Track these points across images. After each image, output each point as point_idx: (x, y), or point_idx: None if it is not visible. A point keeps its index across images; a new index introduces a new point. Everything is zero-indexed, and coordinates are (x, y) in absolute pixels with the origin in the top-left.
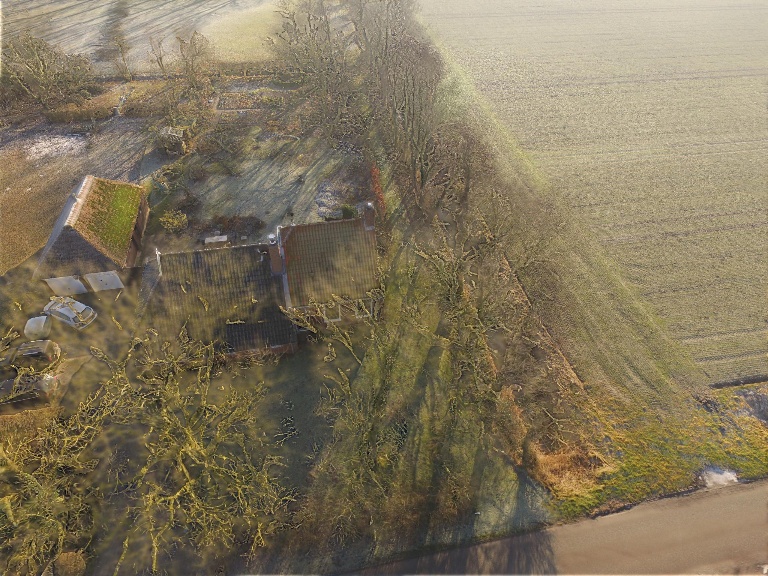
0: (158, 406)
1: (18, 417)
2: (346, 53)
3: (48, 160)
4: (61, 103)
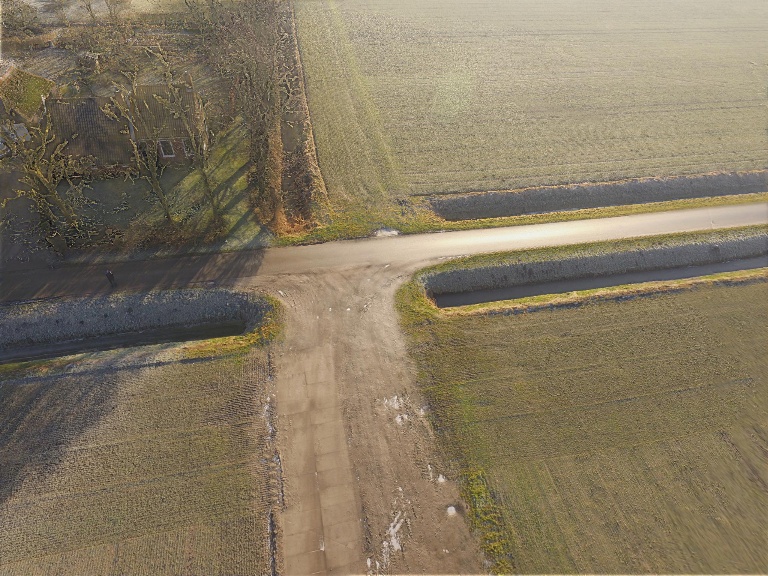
0: (4, 121)
1: None
2: None
3: None
4: (7, 37)
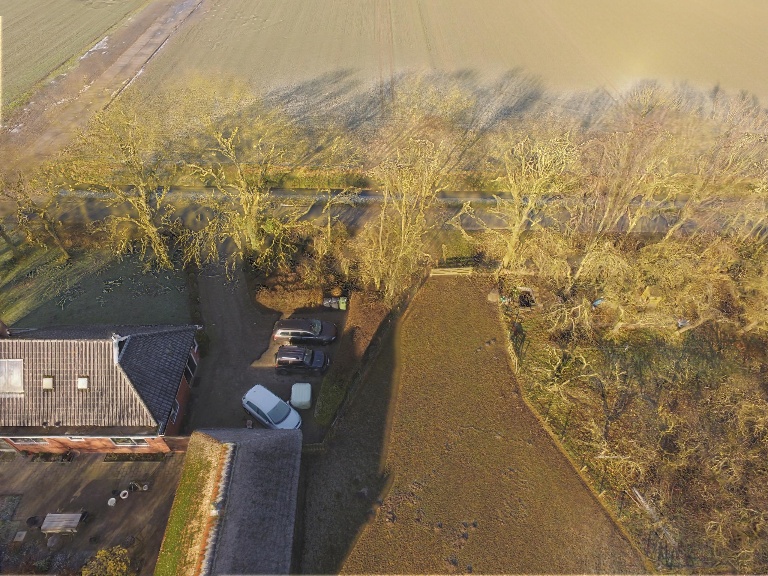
0: None
1: (288, 296)
2: None
3: None
4: None
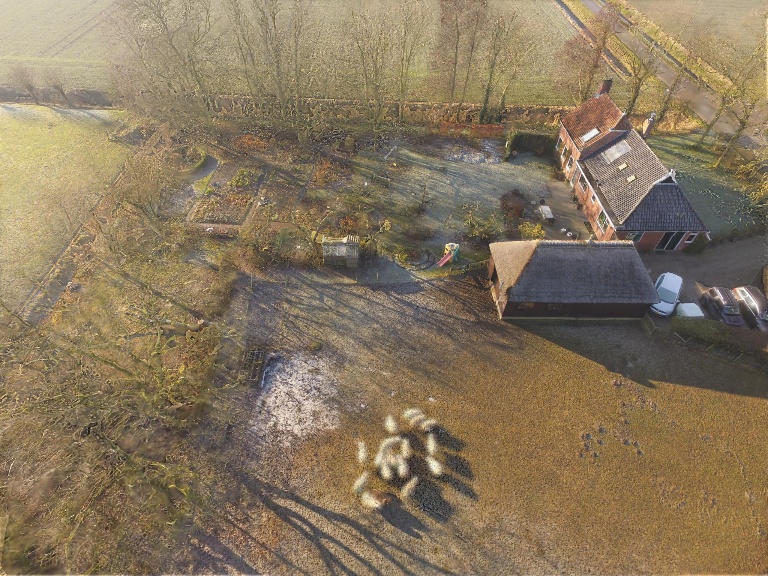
0: None
1: None
2: (117, 119)
3: (347, 394)
4: None
